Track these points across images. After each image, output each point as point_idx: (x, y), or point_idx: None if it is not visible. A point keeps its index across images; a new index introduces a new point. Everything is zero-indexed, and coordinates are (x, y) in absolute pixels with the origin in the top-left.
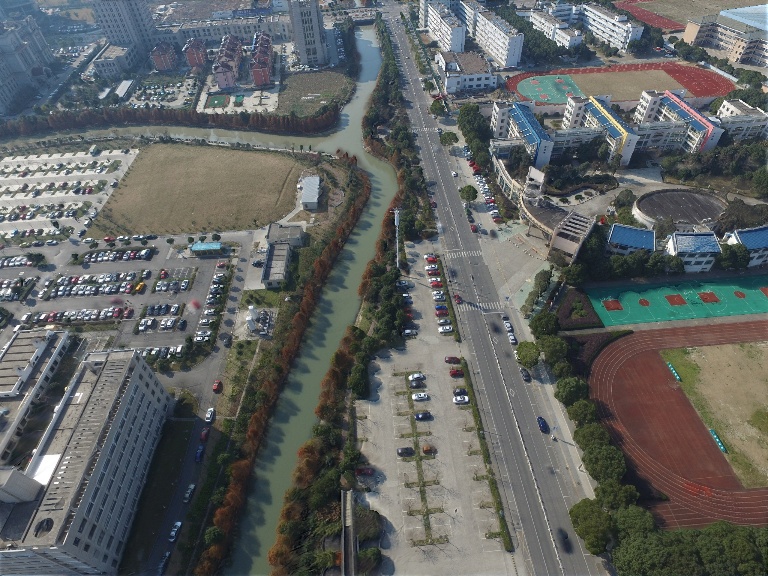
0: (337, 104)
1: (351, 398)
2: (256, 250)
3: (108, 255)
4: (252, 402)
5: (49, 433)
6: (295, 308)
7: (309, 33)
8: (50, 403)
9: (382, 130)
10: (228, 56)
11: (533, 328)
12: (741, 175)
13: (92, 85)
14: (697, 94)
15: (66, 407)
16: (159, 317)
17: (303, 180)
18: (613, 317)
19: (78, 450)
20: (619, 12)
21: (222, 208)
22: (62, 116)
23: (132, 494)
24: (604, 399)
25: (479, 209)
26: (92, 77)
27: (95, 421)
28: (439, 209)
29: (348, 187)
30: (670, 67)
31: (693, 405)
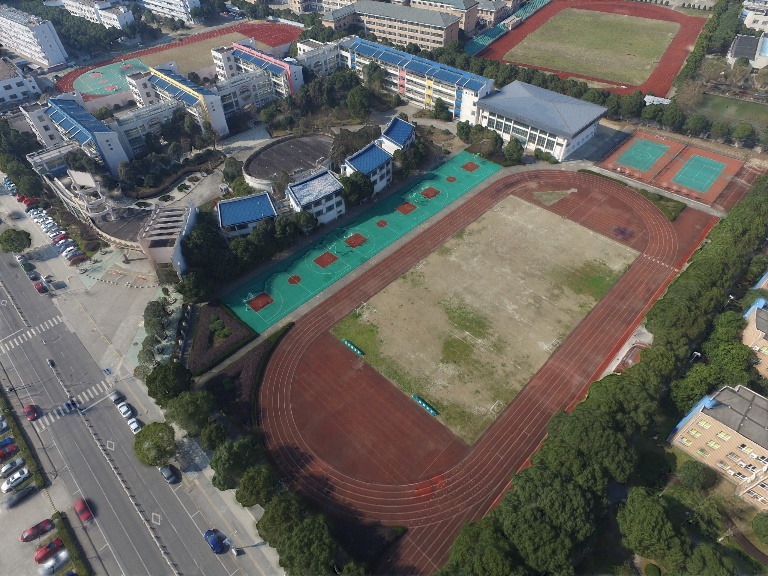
0: None
1: None
2: None
3: None
4: None
5: None
6: None
7: None
8: None
9: None
10: None
11: (153, 397)
12: (337, 106)
13: None
14: None
15: None
16: None
17: None
18: (265, 317)
19: None
20: None
21: None
22: None
23: None
24: (287, 438)
25: (45, 256)
26: None
27: None
28: None
29: None
30: (243, 28)
31: (386, 377)
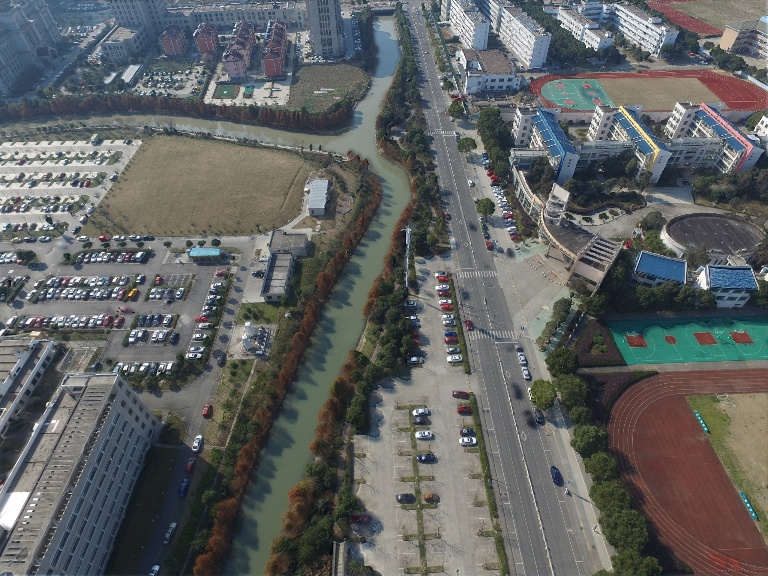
0: (351, 101)
1: (349, 433)
2: (257, 258)
3: (102, 256)
4: (243, 431)
5: (19, 466)
6: (295, 326)
7: (325, 23)
8: (30, 420)
9: (397, 131)
10: (240, 44)
11: (550, 365)
12: None
13: (98, 69)
14: (733, 106)
15: (40, 436)
16: (151, 328)
17: (311, 183)
18: (636, 355)
19: (47, 491)
20: (652, 13)
21: (224, 210)
22: (65, 101)
23: (108, 532)
24: (624, 449)
25: (496, 224)
26: (99, 60)
27: (68, 457)
28: (453, 222)
29: (358, 193)
30: (705, 75)
31: (722, 462)
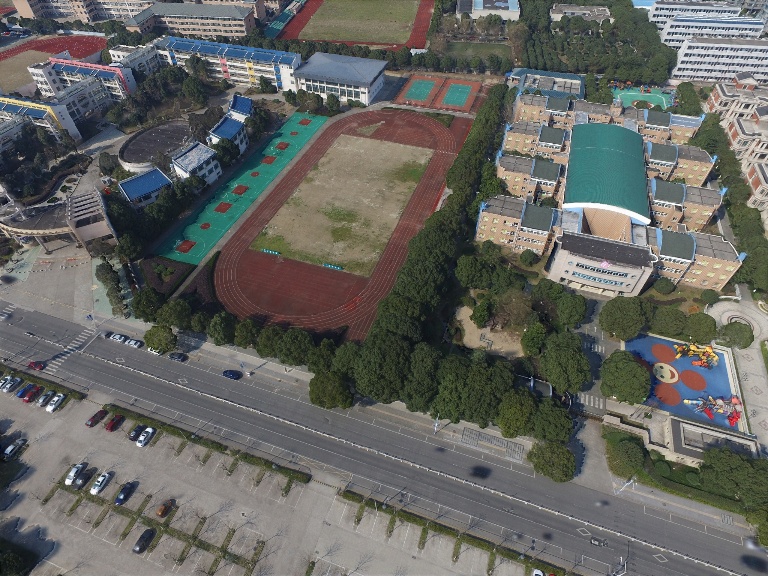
0: None
1: None
2: None
3: None
4: None
5: None
6: None
7: None
8: None
9: None
10: None
11: (142, 316)
12: (176, 97)
13: None
14: (83, 57)
15: None
16: None
17: None
18: (195, 254)
19: None
20: None
21: None
22: None
23: None
24: (251, 312)
25: None
26: None
27: None
28: None
29: None
30: (35, 45)
31: (301, 261)
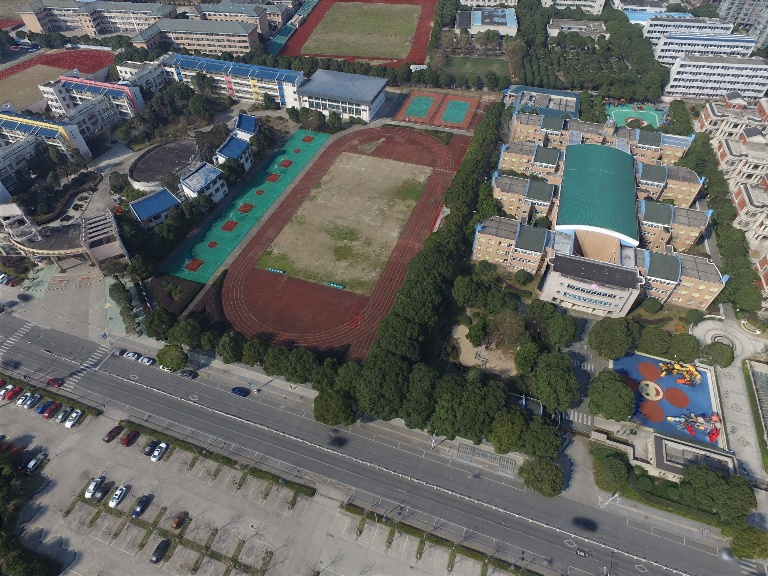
0: None
1: None
2: None
3: None
4: None
5: None
6: None
7: None
8: None
9: None
10: None
11: (154, 335)
12: (182, 115)
13: None
14: (90, 72)
15: None
16: None
17: None
18: (204, 272)
19: None
20: None
21: None
22: None
23: None
24: (257, 330)
25: None
26: None
27: None
28: None
29: None
30: (44, 59)
31: (305, 279)
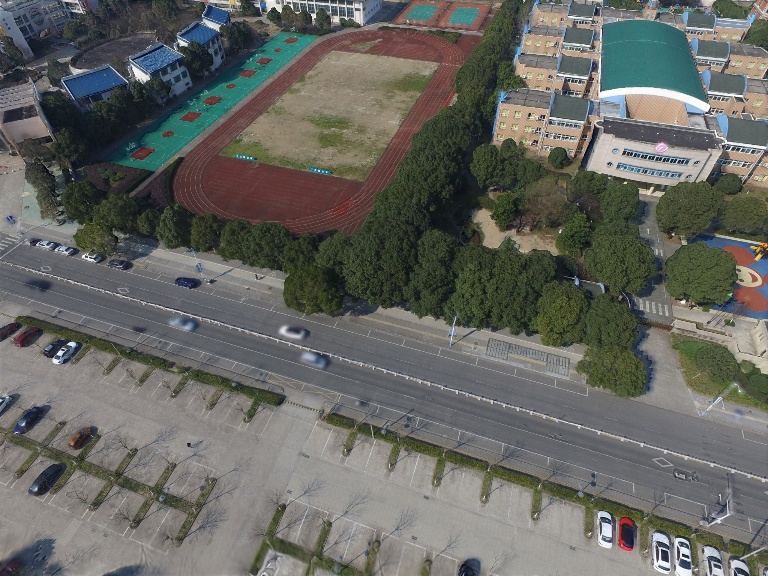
0: None
1: None
2: None
3: None
4: None
5: None
6: None
7: None
8: None
9: None
10: None
11: (75, 215)
12: None
13: None
14: None
15: None
16: None
17: None
18: (153, 160)
19: None
20: None
21: None
22: None
23: None
24: None
25: None
26: None
27: None
28: None
29: None
30: None
31: (281, 166)
